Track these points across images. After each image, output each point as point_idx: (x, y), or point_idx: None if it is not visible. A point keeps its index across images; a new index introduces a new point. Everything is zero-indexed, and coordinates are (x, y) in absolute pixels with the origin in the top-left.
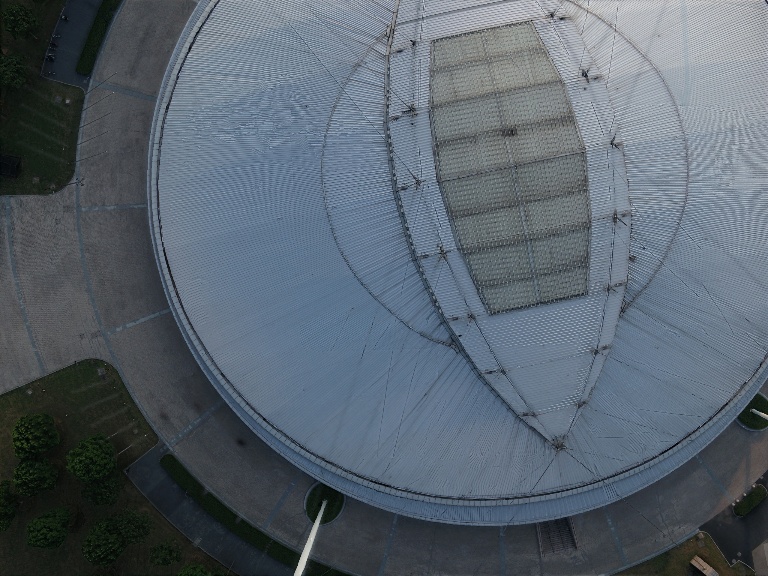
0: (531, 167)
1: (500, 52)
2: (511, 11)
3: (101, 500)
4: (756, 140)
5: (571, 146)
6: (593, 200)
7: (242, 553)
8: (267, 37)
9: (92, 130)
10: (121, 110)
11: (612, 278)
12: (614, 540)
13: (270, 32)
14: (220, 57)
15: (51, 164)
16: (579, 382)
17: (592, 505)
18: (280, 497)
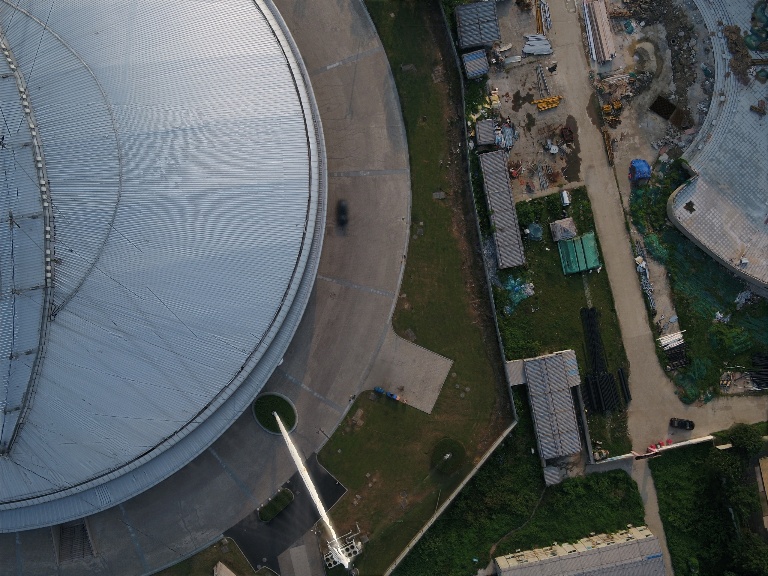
0: None
1: None
2: None
3: None
4: (212, 139)
5: None
6: None
7: None
8: None
9: None
10: None
11: (27, 281)
12: (135, 547)
13: None
14: None
15: None
16: None
17: (84, 512)
18: None
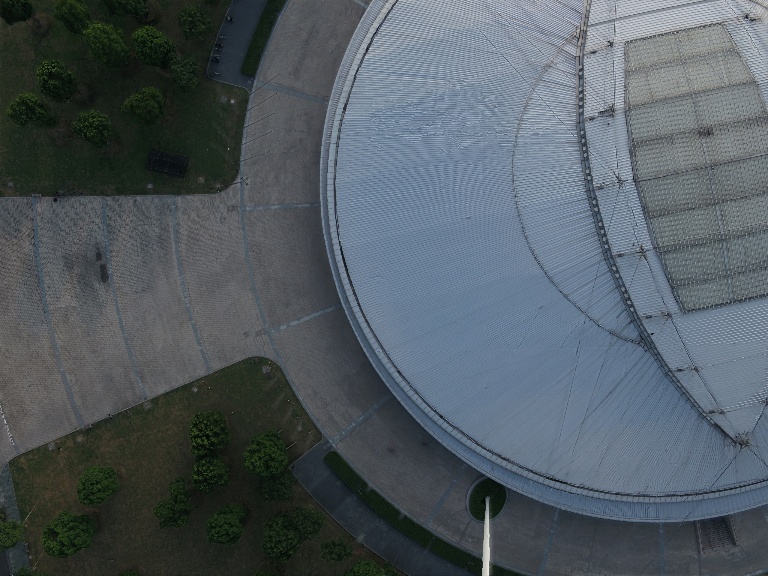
0: (727, 167)
1: (694, 53)
2: (703, 12)
3: (278, 496)
4: None
5: (766, 146)
6: None
7: (405, 549)
8: (451, 38)
9: (256, 130)
10: (285, 110)
11: None
12: None
13: (454, 33)
14: (401, 58)
15: (216, 164)
16: (766, 380)
17: (759, 502)
18: (442, 494)
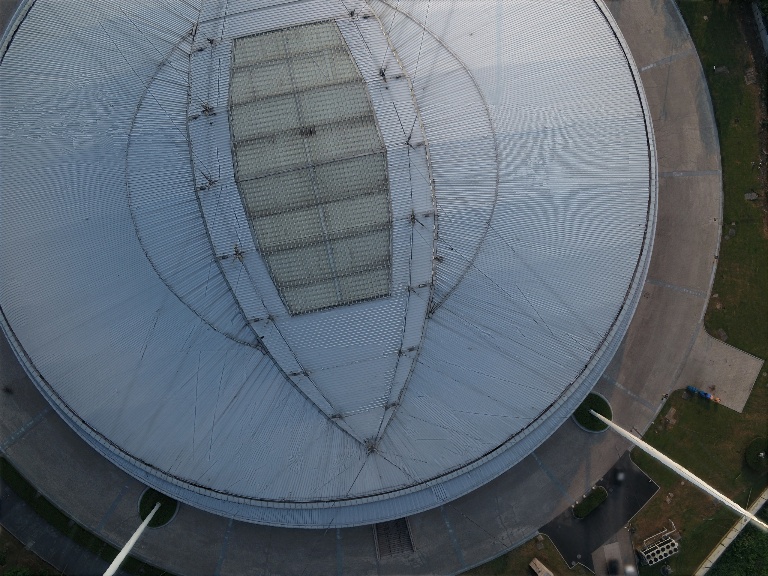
0: (330, 167)
1: (301, 51)
2: (314, 10)
3: None
4: (573, 140)
5: (371, 146)
6: (394, 200)
7: (75, 556)
8: (78, 36)
9: None
10: None
11: (416, 279)
12: (452, 542)
13: (81, 31)
14: (34, 56)
15: None
16: (387, 384)
17: (421, 507)
18: (114, 500)
